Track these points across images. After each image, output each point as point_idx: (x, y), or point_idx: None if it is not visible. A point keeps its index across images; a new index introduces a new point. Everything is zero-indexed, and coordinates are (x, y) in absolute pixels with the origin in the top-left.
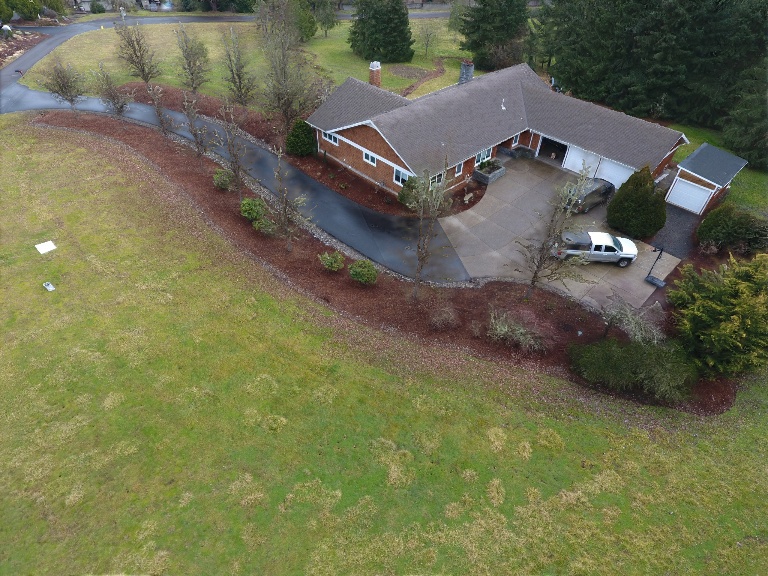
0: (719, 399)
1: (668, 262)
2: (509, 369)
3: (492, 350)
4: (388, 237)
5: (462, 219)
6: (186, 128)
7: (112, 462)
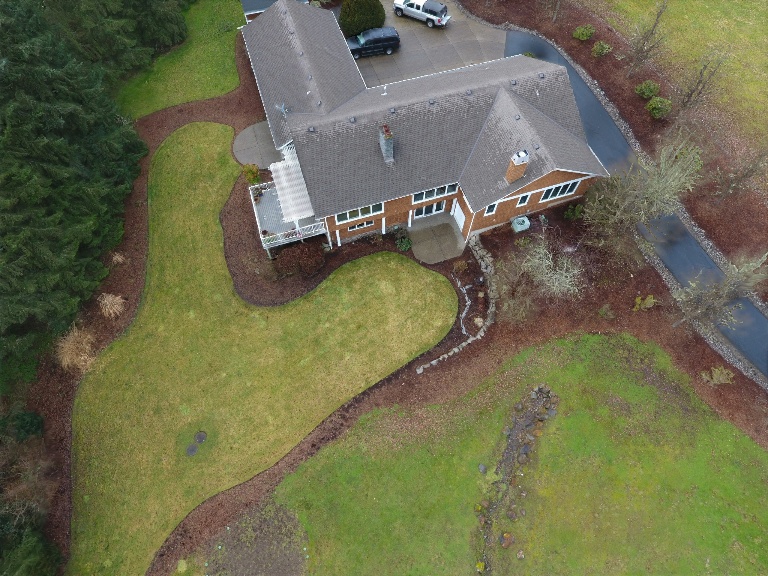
0: None
1: None
2: None
3: None
4: None
5: None
6: (764, 336)
7: None
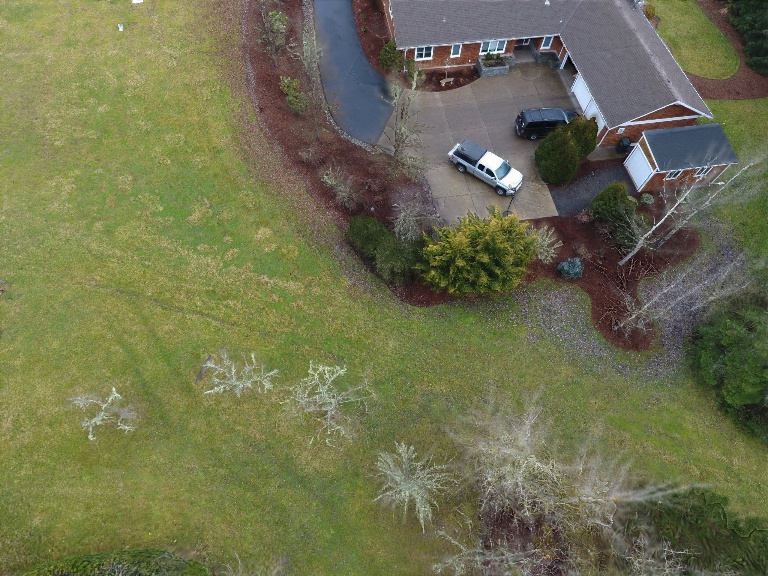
0: (424, 299)
1: (544, 211)
2: (317, 207)
3: (322, 192)
4: (354, 86)
5: (423, 97)
6: None
7: (82, 137)
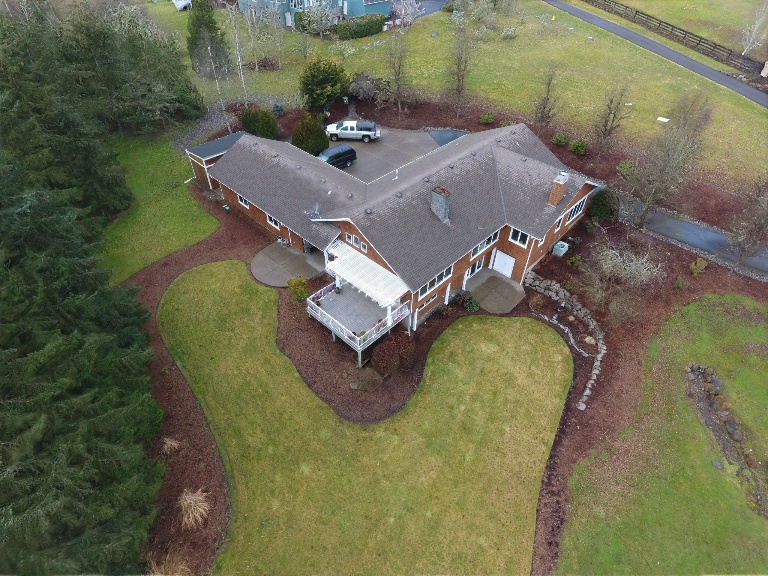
0: None
1: None
2: None
3: None
4: None
5: None
6: None
7: None
